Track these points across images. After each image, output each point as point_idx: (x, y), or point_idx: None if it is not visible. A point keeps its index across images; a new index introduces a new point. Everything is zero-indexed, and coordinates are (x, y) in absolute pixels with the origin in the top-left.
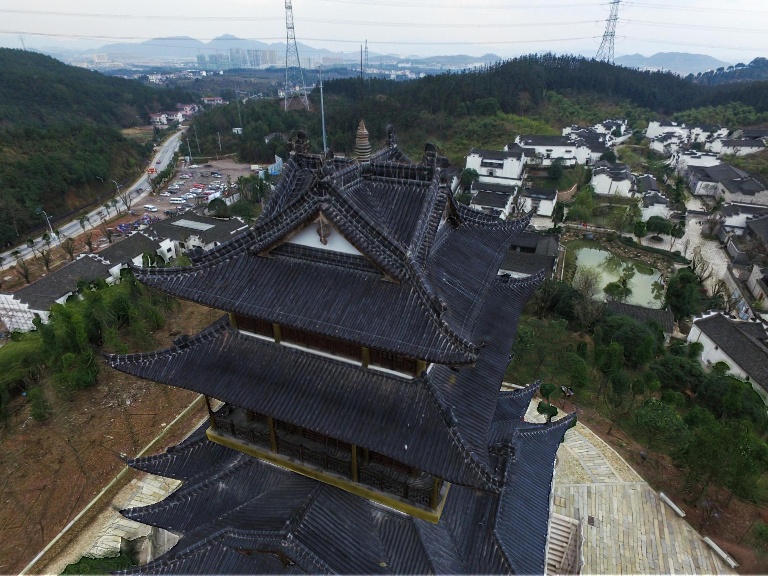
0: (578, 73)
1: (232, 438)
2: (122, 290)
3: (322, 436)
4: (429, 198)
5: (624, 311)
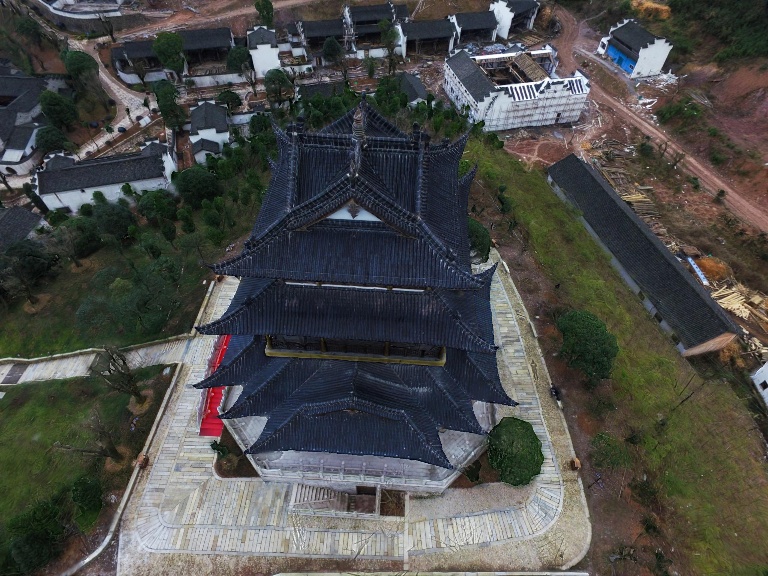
0: None
1: None
2: None
3: None
4: None
5: None
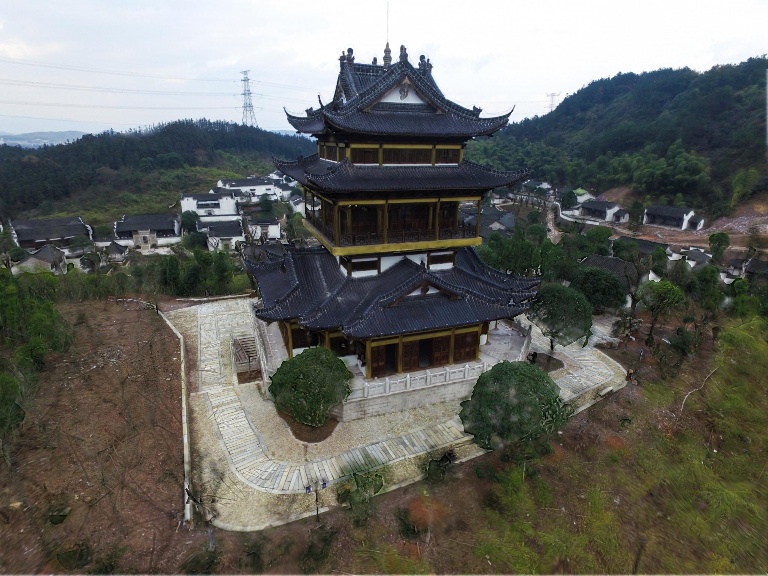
0: (236, 135)
1: (354, 246)
2: None
3: None
4: None
5: None
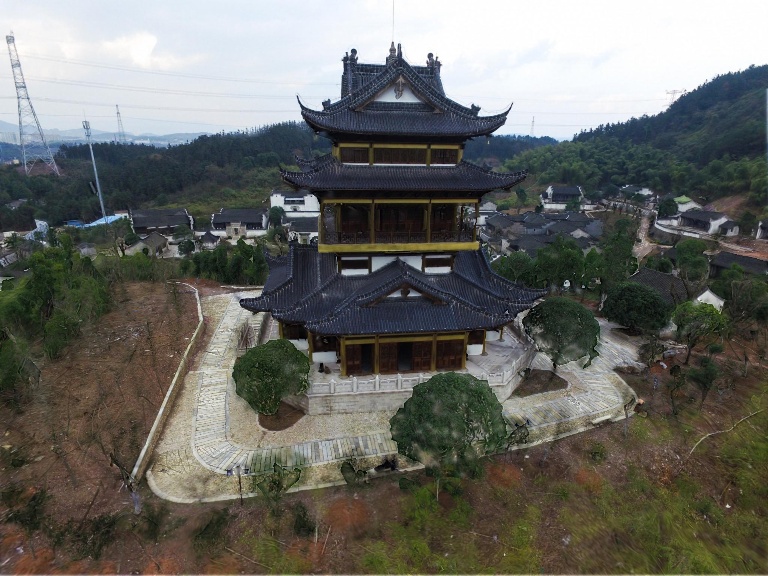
0: None
1: (339, 244)
2: None
3: None
4: None
5: None
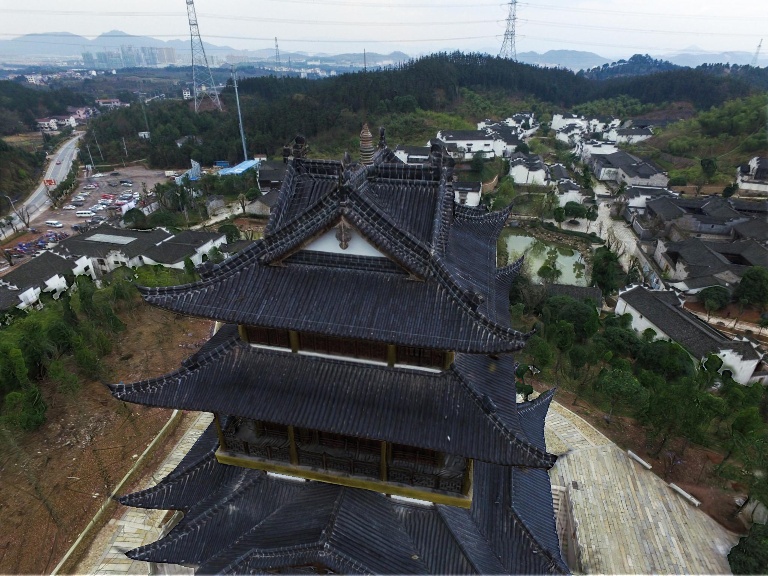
0: (486, 70)
1: (246, 457)
2: (52, 316)
3: (341, 441)
4: (441, 197)
5: (559, 291)
